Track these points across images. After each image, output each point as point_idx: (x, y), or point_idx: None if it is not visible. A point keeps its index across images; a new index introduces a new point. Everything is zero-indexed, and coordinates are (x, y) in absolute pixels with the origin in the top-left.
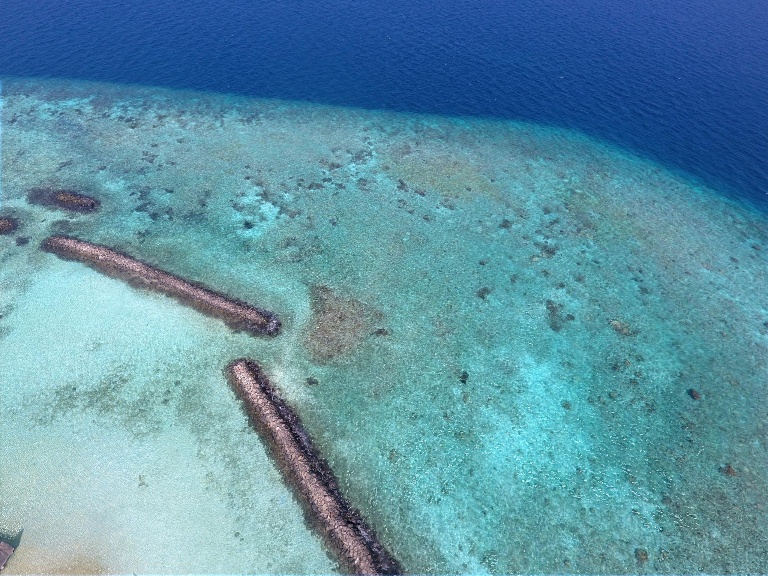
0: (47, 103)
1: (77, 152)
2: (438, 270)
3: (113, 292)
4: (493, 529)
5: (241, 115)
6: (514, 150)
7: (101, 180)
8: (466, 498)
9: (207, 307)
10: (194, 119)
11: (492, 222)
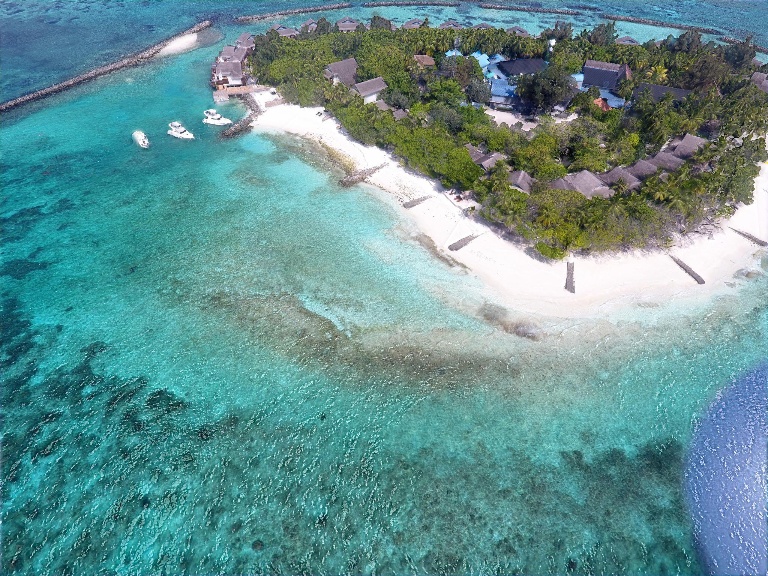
0: None
1: None
2: (763, 25)
3: None
4: None
5: None
6: None
7: None
8: None
9: None
10: None
11: None
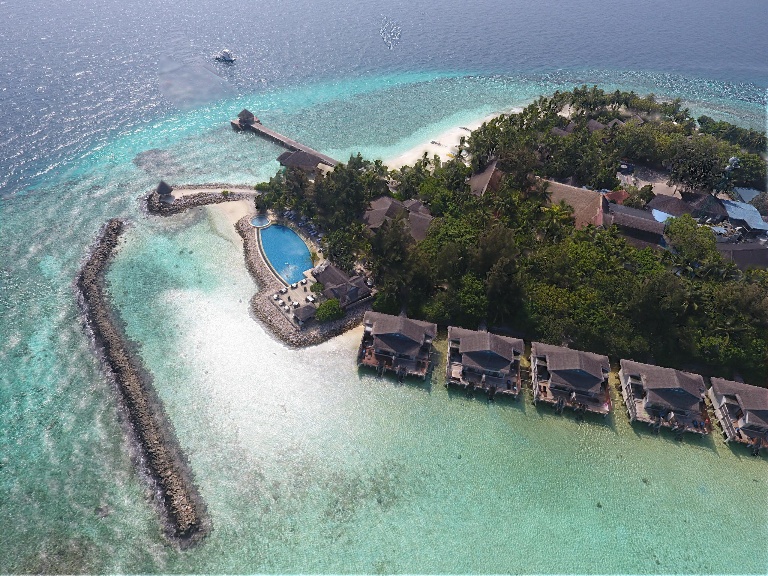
0: None
1: None
2: None
3: None
4: (3, 369)
5: None
6: None
7: None
8: (8, 389)
9: None
10: None
11: None
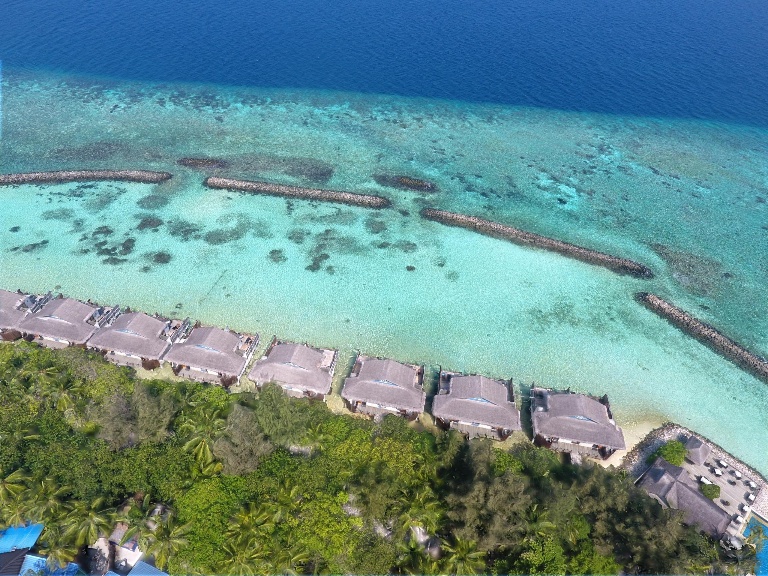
0: (317, 109)
1: (379, 147)
2: (735, 233)
3: (506, 248)
4: None
5: (480, 117)
6: (722, 143)
7: (419, 168)
8: None
9: (587, 258)
10: (446, 120)
11: (749, 198)
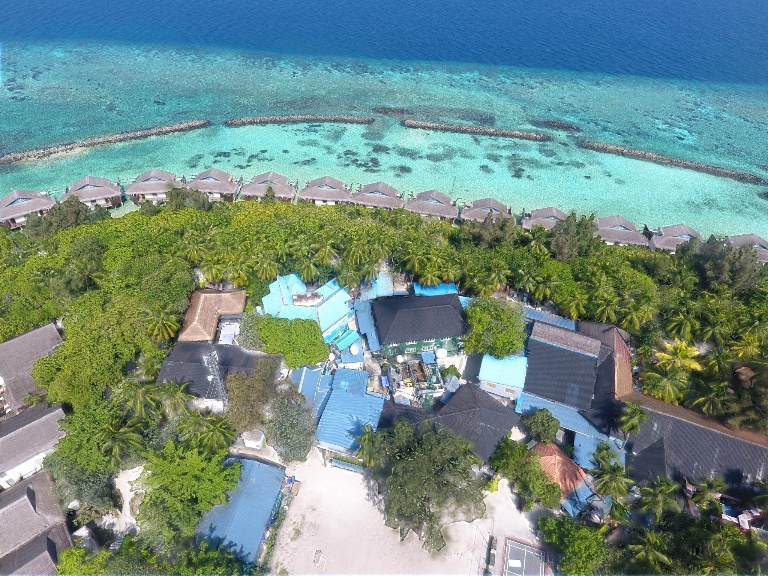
0: (455, 75)
1: (520, 102)
2: None
3: (652, 166)
4: None
5: (589, 82)
6: None
7: (559, 116)
8: None
9: (715, 172)
10: (562, 84)
11: None
